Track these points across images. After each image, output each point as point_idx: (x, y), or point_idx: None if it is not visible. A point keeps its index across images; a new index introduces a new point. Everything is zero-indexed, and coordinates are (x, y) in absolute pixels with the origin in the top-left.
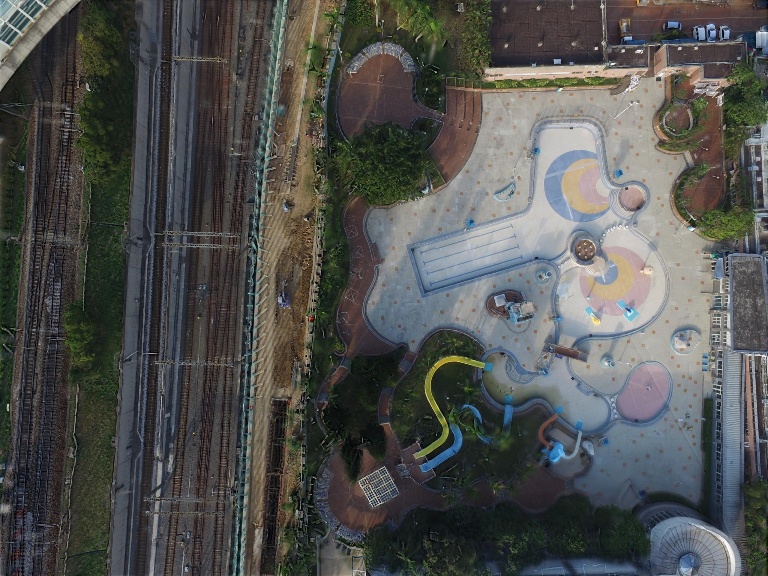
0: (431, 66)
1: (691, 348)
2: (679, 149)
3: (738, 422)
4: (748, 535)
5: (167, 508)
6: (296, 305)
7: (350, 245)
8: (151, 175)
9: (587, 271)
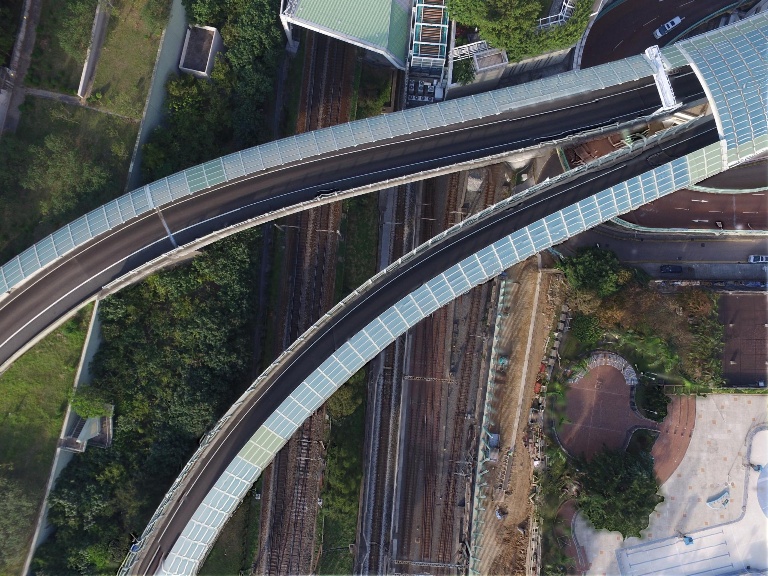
0: (650, 374)
1: None
2: None
3: None
4: None
5: None
6: None
7: (560, 551)
8: (369, 483)
9: None
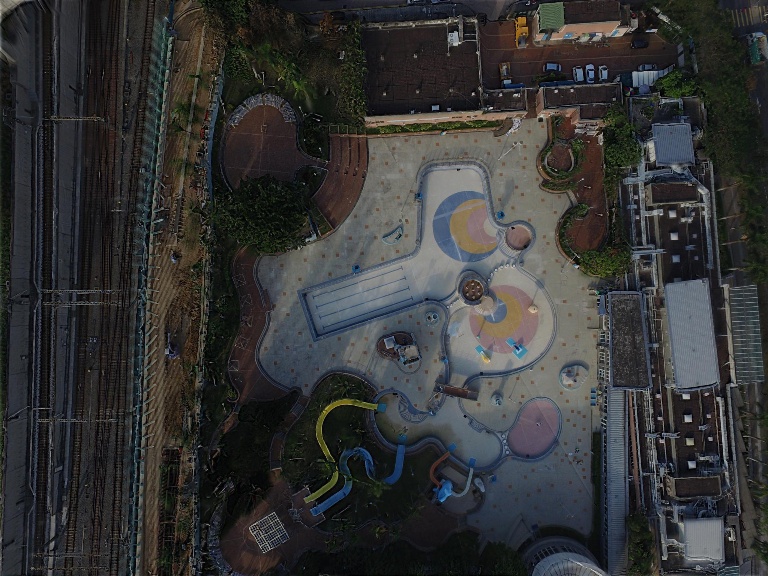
0: (313, 115)
1: (578, 383)
2: (562, 188)
3: (622, 456)
4: (628, 569)
5: (61, 560)
6: (186, 355)
7: (240, 293)
8: (36, 232)
9: (476, 310)
